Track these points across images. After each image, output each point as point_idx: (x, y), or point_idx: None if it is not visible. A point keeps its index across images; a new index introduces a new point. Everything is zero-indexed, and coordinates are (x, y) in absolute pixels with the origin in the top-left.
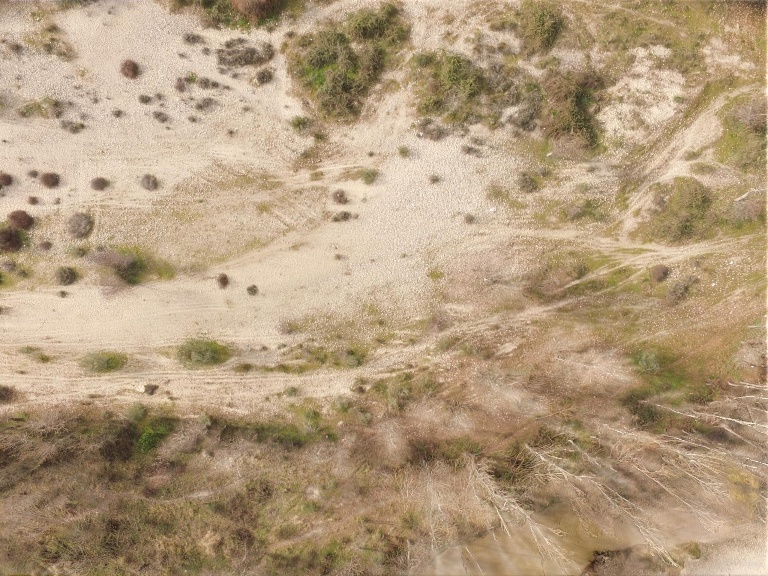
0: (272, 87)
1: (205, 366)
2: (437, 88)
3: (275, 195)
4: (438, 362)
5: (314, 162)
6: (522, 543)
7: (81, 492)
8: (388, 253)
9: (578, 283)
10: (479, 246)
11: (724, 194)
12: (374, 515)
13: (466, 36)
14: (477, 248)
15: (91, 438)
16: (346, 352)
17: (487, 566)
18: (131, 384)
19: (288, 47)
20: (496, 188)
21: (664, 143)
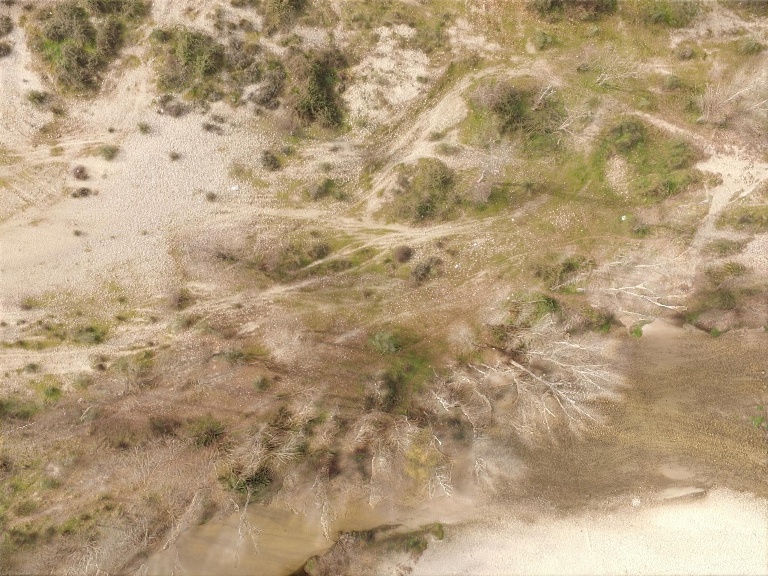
0: (11, 61)
1: None
2: (175, 64)
3: (15, 170)
4: (180, 340)
5: (54, 137)
6: (267, 522)
7: None
8: (128, 230)
9: (321, 263)
10: (221, 224)
11: (467, 175)
12: (114, 493)
13: (207, 12)
14: (219, 226)
15: None
16: (85, 329)
17: (231, 545)
18: None
19: (27, 20)
20: (238, 166)
21: (409, 123)
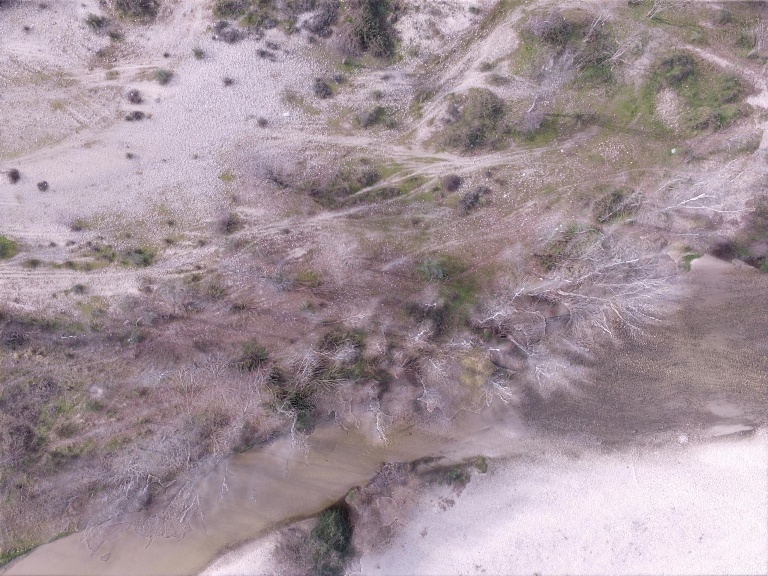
0: None
1: None
2: None
3: (70, 93)
4: (227, 265)
5: (109, 61)
6: (309, 452)
7: None
8: (180, 154)
9: (369, 190)
10: (271, 150)
11: (517, 106)
12: (157, 416)
13: None
14: (269, 152)
15: None
16: (134, 251)
17: (273, 474)
18: None
19: None
20: (290, 93)
21: (460, 54)
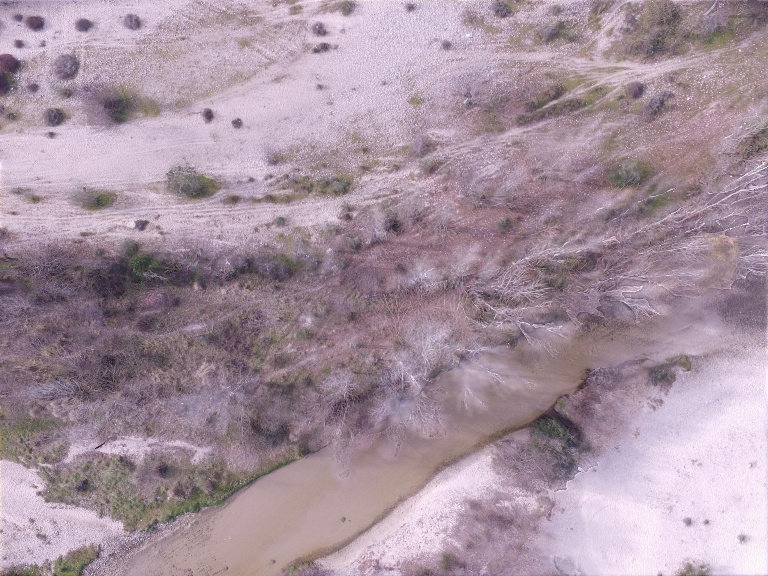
0: None
1: (194, 200)
2: None
3: (256, 30)
4: (423, 187)
5: None
6: (514, 364)
7: (76, 329)
8: (368, 81)
9: (556, 103)
10: (457, 71)
11: (693, 10)
12: (367, 340)
13: None
14: (455, 73)
15: (84, 274)
16: (332, 179)
17: (481, 389)
18: (122, 220)
19: None
20: (471, 14)
21: None
